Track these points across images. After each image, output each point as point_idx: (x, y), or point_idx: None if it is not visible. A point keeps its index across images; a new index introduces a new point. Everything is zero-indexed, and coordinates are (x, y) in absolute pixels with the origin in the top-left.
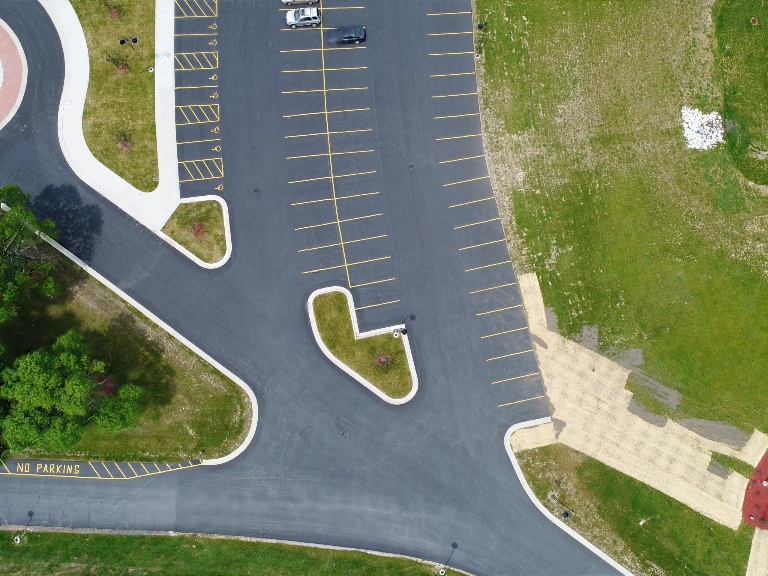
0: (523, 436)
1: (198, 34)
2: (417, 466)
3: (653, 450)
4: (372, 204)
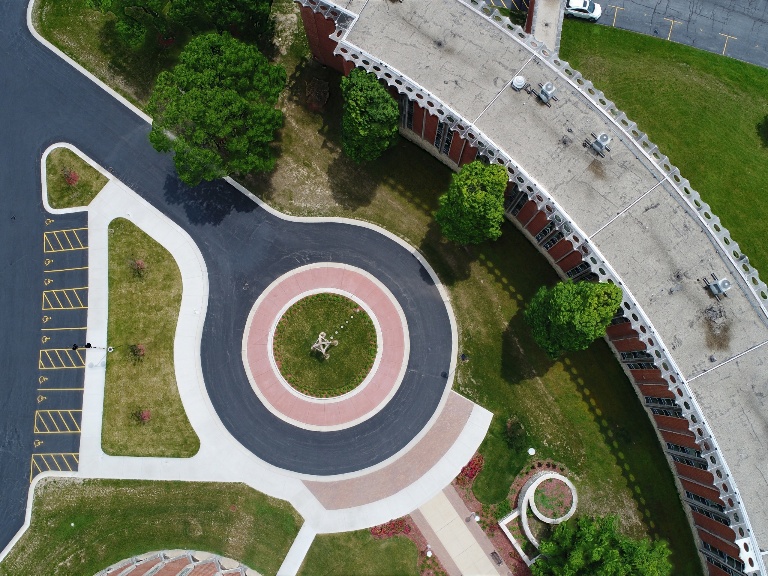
0: None
1: (58, 390)
2: None
3: None
4: None
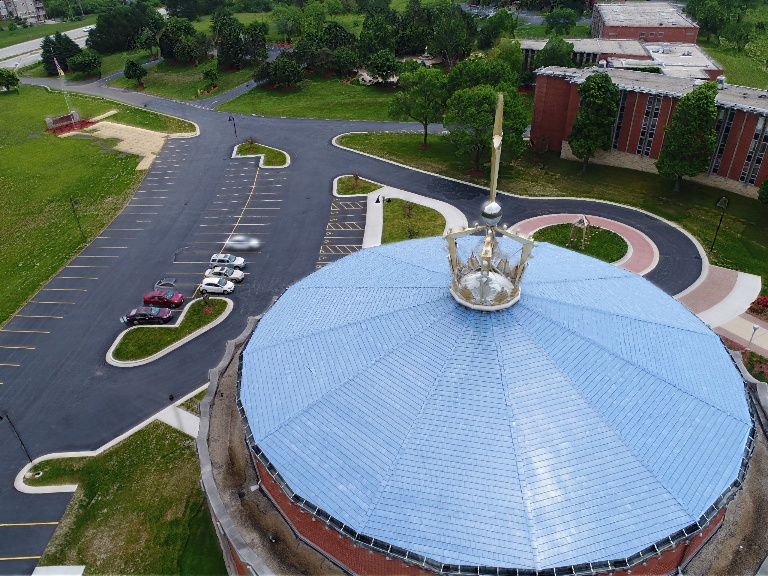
0: (188, 135)
1: None
2: (250, 131)
3: (122, 133)
4: (225, 192)
